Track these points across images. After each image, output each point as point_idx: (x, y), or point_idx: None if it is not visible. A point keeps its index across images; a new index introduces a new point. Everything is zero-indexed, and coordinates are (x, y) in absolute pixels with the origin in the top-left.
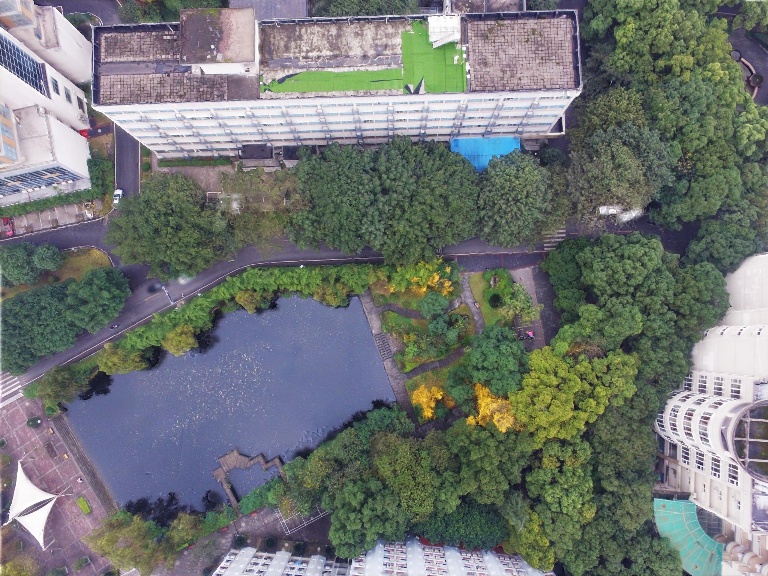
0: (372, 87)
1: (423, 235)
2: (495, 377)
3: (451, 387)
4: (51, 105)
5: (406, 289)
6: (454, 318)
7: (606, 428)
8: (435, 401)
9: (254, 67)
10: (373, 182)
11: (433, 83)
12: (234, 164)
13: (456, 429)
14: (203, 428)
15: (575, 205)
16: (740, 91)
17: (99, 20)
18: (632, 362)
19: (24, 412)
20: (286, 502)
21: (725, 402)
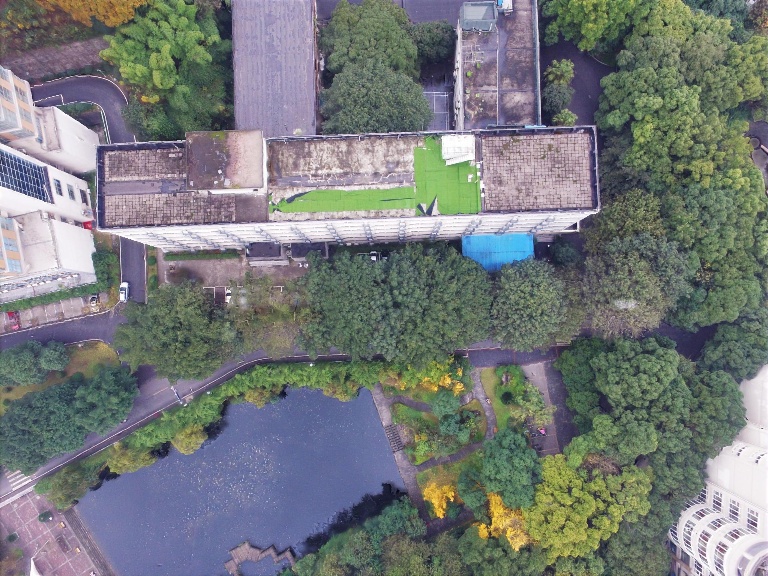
0: (384, 207)
1: (435, 346)
2: (508, 490)
3: (463, 491)
4: (54, 208)
5: None
6: (465, 415)
7: (620, 547)
8: (446, 499)
9: None
10: (385, 297)
11: (446, 202)
12: (241, 257)
13: (468, 539)
14: (214, 520)
15: (590, 314)
16: (761, 197)
17: (100, 108)
18: (647, 481)
19: (35, 506)
20: None
21: (742, 536)
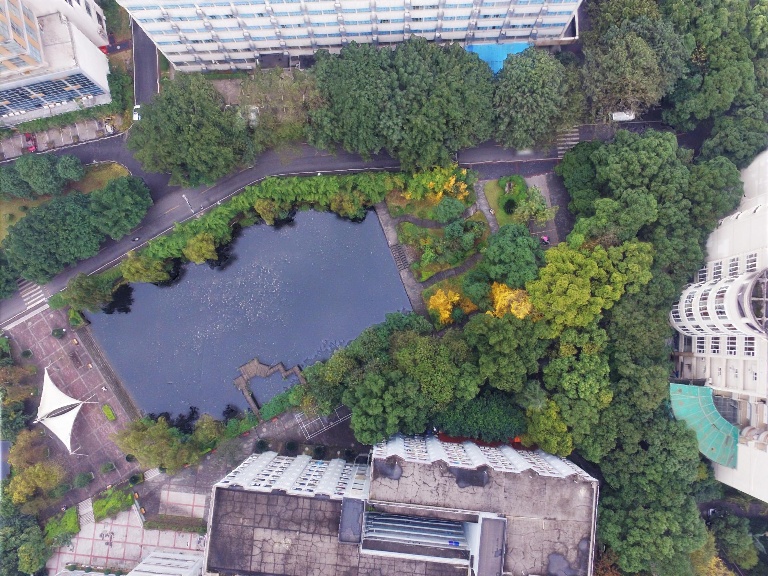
0: None
1: (440, 132)
2: (512, 269)
3: (468, 287)
4: (72, 13)
5: (422, 198)
6: (470, 224)
7: (622, 313)
8: (452, 305)
9: None
10: (391, 76)
11: None
12: (251, 77)
13: (474, 322)
14: (223, 338)
15: (590, 101)
16: None
17: None
18: (648, 248)
19: (49, 324)
20: (307, 399)
21: (741, 274)
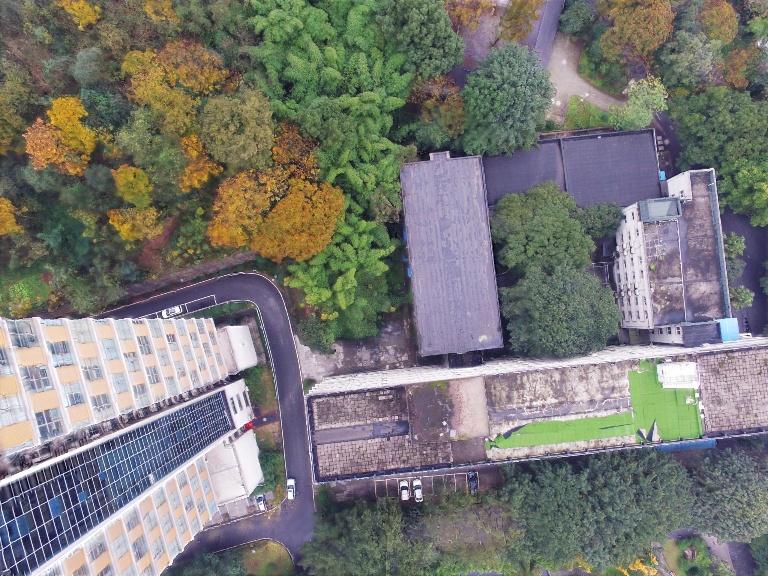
0: (603, 435)
1: None
2: None
3: None
4: None
5: None
6: None
7: None
8: None
9: None
10: (597, 514)
11: (666, 426)
12: None
13: None
14: None
15: None
16: None
17: (255, 305)
18: None
19: None
20: None
21: None
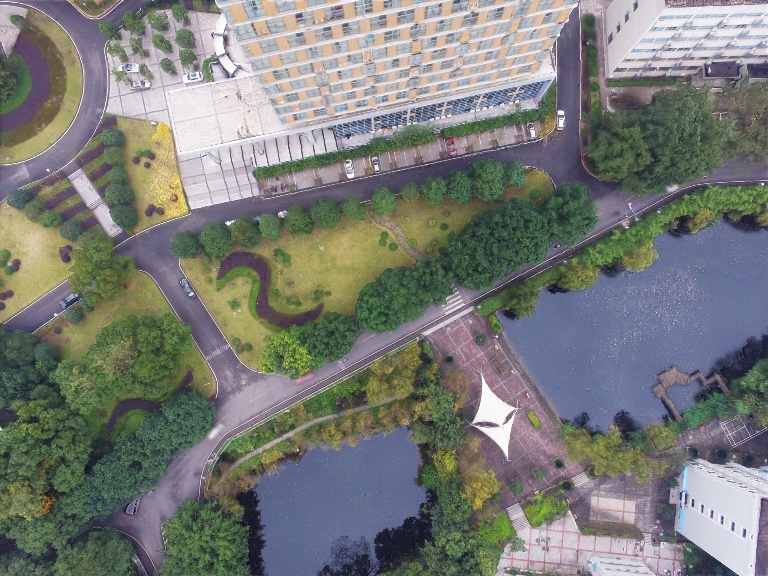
0: None
1: None
2: None
3: None
4: None
5: None
6: None
7: None
8: None
9: None
10: None
11: None
12: None
13: None
14: (640, 346)
15: None
16: None
17: None
18: None
19: (468, 330)
20: None
21: None
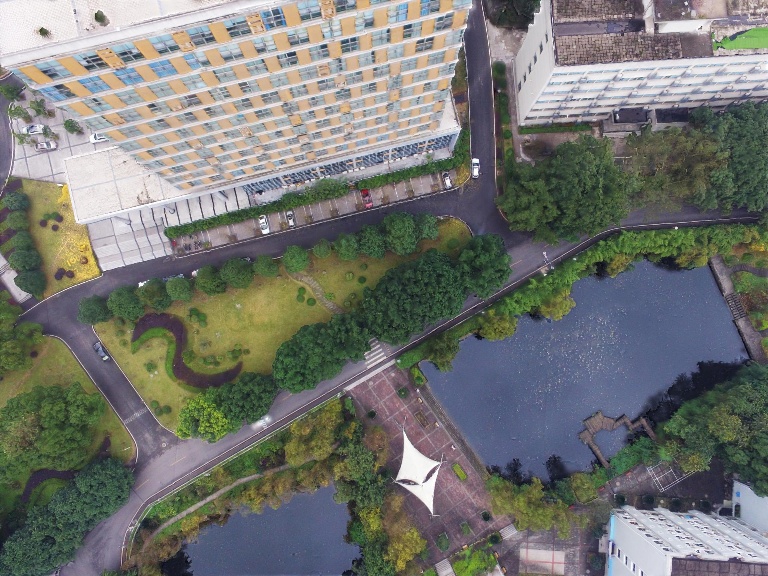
0: None
1: None
2: None
3: None
4: None
5: None
6: None
7: None
8: None
9: (707, 25)
10: None
11: None
12: (593, 130)
13: None
14: (565, 392)
15: None
16: None
17: None
18: None
19: (391, 383)
20: (695, 457)
21: None
